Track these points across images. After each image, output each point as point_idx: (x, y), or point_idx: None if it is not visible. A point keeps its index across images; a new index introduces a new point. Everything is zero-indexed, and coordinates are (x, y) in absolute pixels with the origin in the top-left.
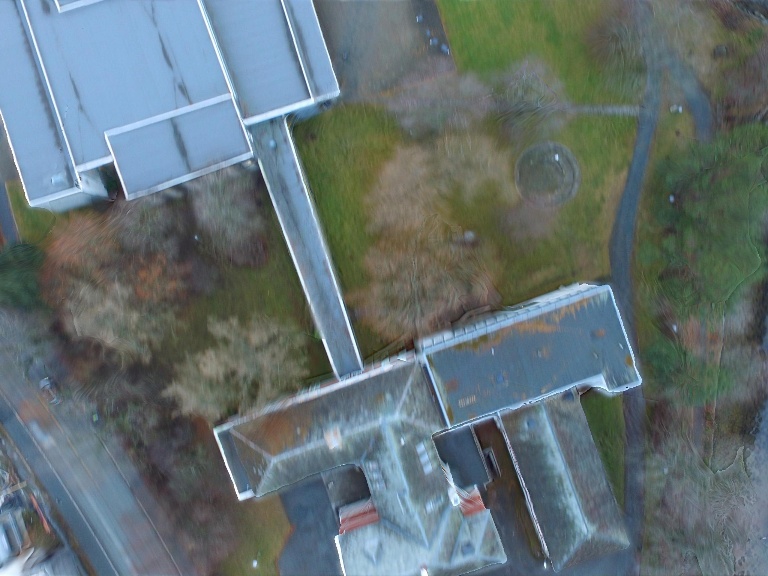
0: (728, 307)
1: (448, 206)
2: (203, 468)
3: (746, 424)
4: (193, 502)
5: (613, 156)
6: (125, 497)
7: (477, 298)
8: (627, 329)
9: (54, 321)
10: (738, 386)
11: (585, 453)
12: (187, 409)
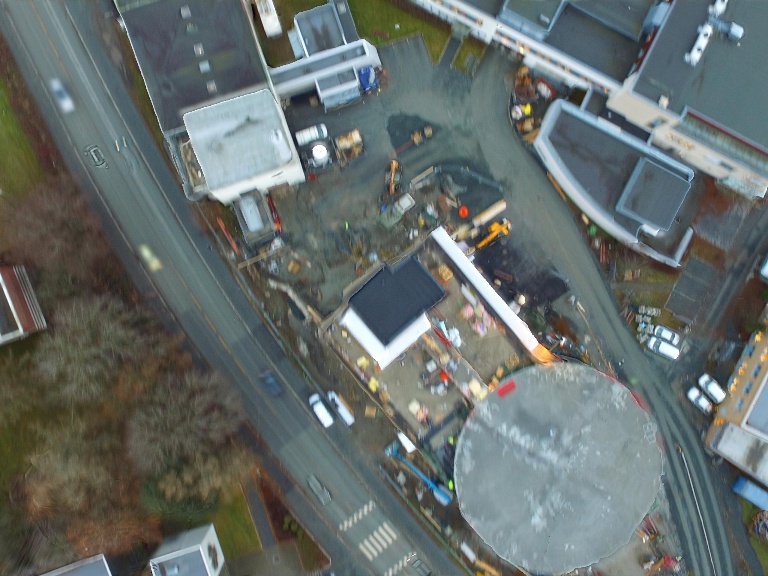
0: None
1: None
2: (63, 282)
3: None
4: (75, 248)
5: None
6: (145, 252)
7: None
8: None
9: (126, 459)
10: None
11: None
12: (31, 361)
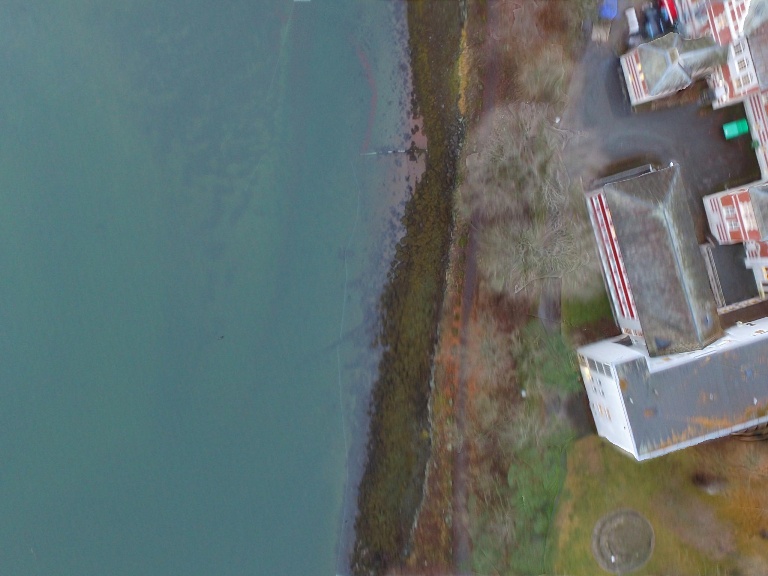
0: (424, 394)
1: (732, 520)
2: None
3: (407, 273)
4: None
5: (560, 559)
6: None
7: (760, 451)
8: (562, 391)
9: None
10: (414, 312)
11: (651, 286)
12: None
